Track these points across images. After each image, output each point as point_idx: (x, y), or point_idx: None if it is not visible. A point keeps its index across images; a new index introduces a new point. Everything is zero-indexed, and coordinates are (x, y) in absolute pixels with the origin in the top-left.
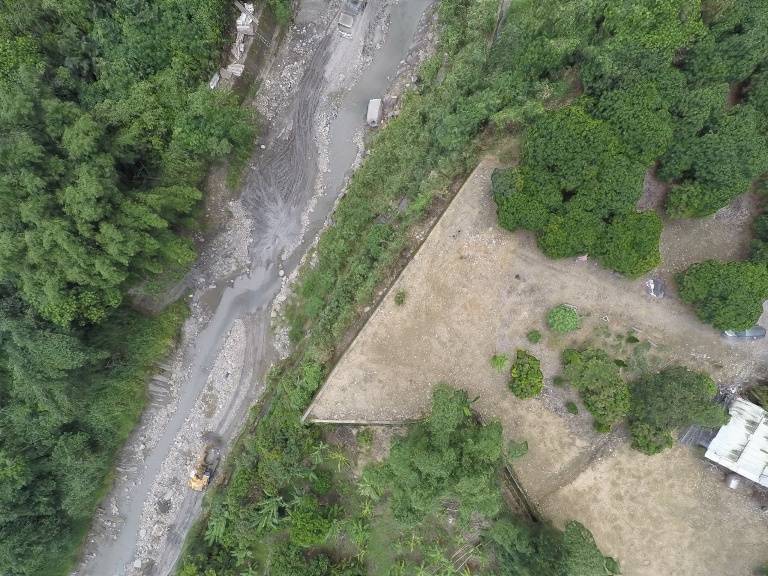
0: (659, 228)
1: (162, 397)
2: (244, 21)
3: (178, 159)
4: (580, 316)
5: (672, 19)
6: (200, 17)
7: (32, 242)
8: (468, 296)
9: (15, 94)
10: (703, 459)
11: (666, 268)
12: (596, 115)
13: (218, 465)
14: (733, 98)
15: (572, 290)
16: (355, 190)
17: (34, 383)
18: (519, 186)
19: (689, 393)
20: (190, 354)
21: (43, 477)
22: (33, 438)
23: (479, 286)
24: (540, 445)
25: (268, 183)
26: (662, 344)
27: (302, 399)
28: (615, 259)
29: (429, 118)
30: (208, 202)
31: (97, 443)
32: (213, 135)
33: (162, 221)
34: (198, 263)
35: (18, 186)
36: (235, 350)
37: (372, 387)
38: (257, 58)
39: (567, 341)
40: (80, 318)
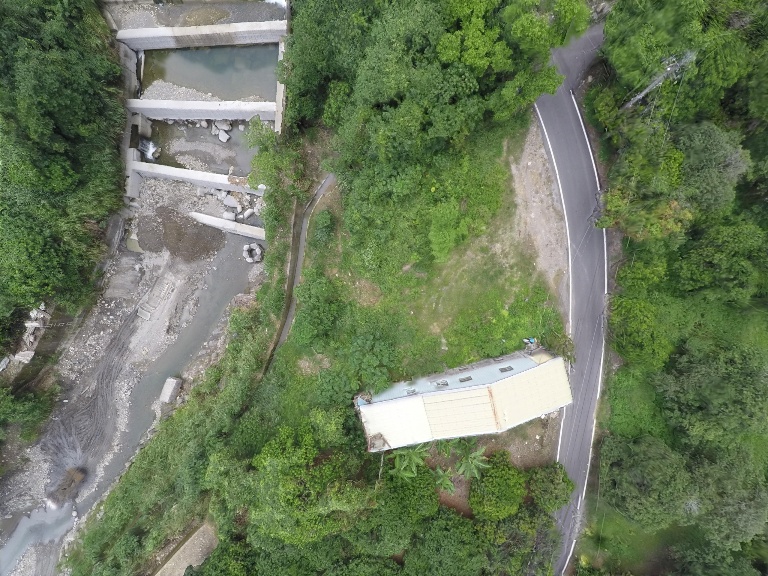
0: None
1: None
2: (36, 315)
3: None
4: None
5: None
6: None
7: None
8: None
9: None
10: None
11: None
12: None
13: None
14: None
15: None
16: (131, 474)
17: None
18: None
19: None
20: None
21: None
22: None
23: None
24: None
25: (68, 433)
26: None
27: None
28: None
29: None
30: (4, 449)
31: None
32: None
33: None
34: None
35: None
36: (24, 575)
37: None
38: (54, 338)
39: None
40: None
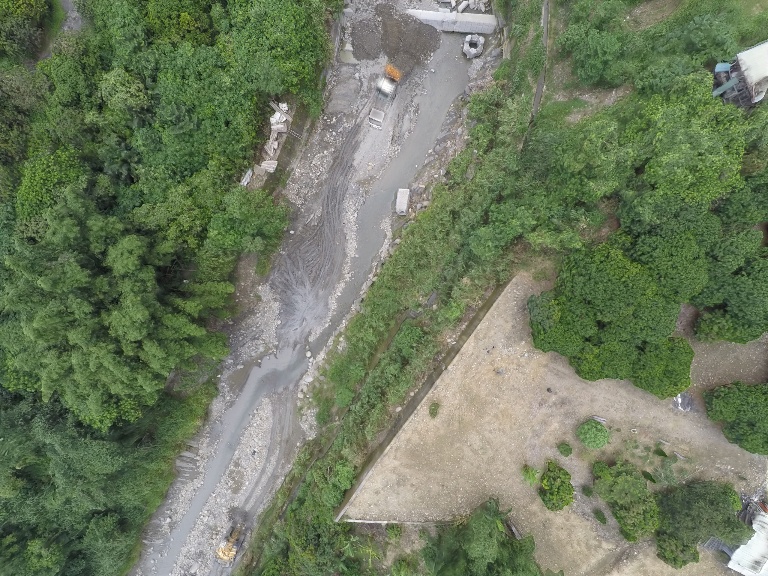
0: (690, 358)
1: (189, 472)
2: (278, 119)
3: (212, 257)
4: (609, 429)
5: (712, 180)
6: (237, 123)
7: (78, 364)
8: (500, 406)
9: (62, 220)
10: (725, 563)
11: (693, 383)
12: (633, 257)
13: (244, 540)
14: (763, 229)
15: (602, 403)
16: (385, 283)
17: (75, 489)
18: (556, 318)
19: (716, 514)
20: (217, 431)
21: (73, 556)
22: (66, 524)
23: (511, 397)
24: (567, 547)
25: (296, 267)
26: (688, 456)
27: (335, 499)
28: (647, 385)
29: (459, 215)
30: (238, 287)
31: (125, 520)
32: (247, 233)
33: (201, 329)
34: (227, 345)
35: (66, 312)
36: (262, 428)
37: (405, 491)
38: (289, 151)
39: (596, 451)
40: (118, 419)
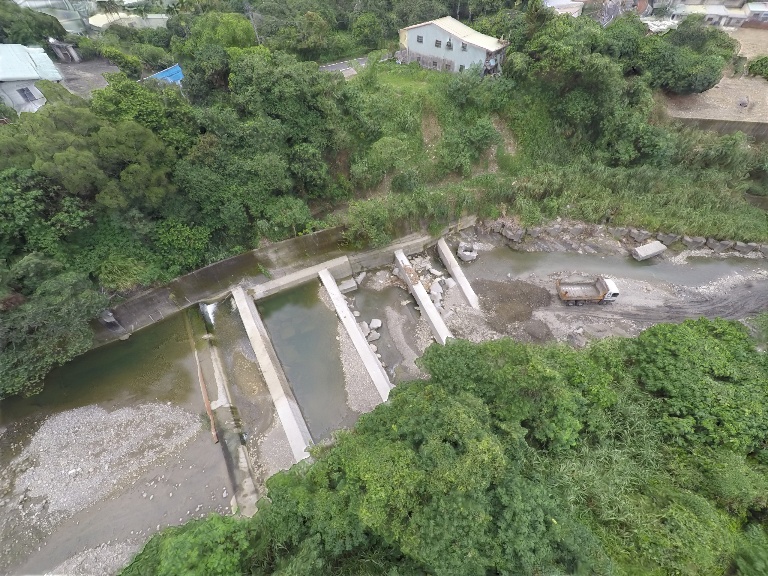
0: None
1: None
2: None
3: None
4: None
5: None
6: None
7: None
8: (760, 100)
9: None
10: None
11: None
12: None
13: None
14: None
15: None
16: None
17: None
18: None
19: None
20: None
21: None
22: None
23: None
24: None
25: None
26: None
27: None
28: None
29: None
30: None
31: None
32: None
33: None
34: None
35: None
36: None
37: None
38: None
39: None
40: None
